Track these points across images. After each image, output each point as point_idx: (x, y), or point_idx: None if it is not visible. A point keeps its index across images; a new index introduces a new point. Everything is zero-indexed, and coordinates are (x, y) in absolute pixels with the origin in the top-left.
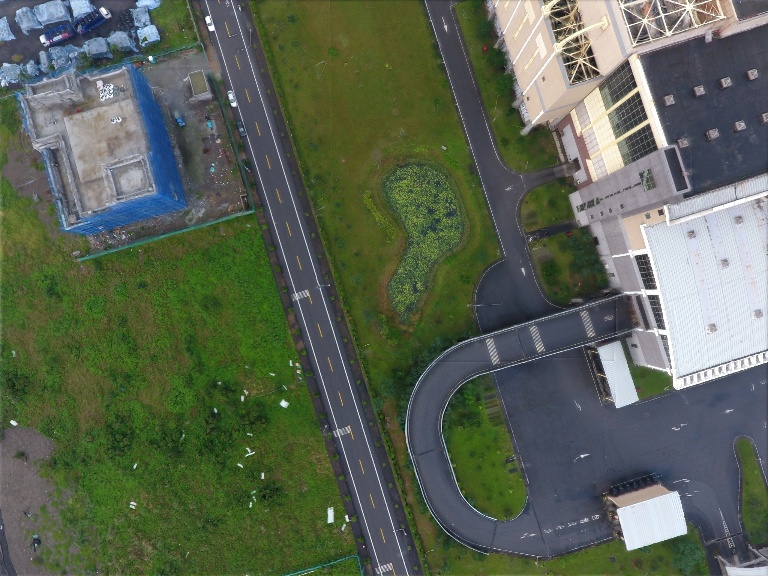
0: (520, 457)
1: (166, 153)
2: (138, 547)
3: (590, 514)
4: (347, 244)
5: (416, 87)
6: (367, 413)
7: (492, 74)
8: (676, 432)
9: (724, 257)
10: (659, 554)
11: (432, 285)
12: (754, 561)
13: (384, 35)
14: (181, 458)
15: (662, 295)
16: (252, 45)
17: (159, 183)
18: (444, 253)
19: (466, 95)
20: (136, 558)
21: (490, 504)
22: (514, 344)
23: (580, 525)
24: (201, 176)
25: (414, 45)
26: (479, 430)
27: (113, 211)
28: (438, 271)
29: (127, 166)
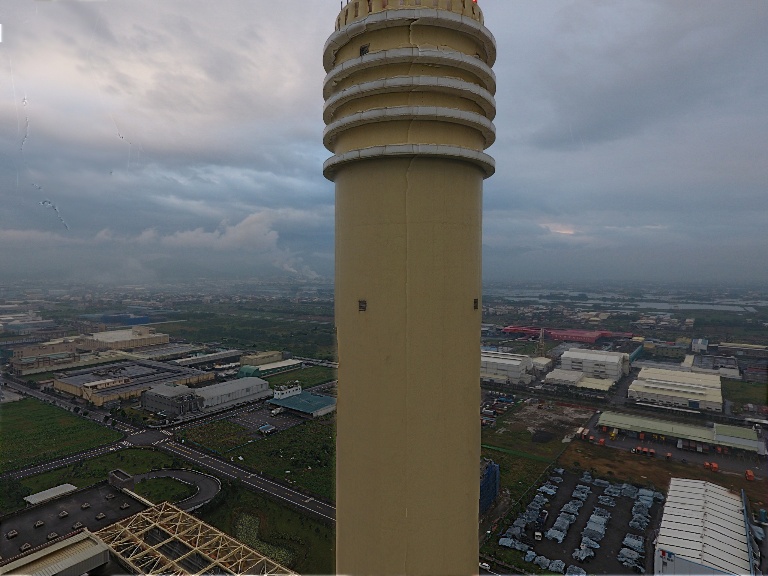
0: None
1: None
2: None
3: None
4: None
5: None
6: None
7: None
8: None
9: None
10: None
11: None
12: None
13: None
14: None
15: None
16: None
17: None
18: None
19: None
20: None
21: None
22: None
23: None
24: None
25: None
26: None
27: None
28: None
29: None
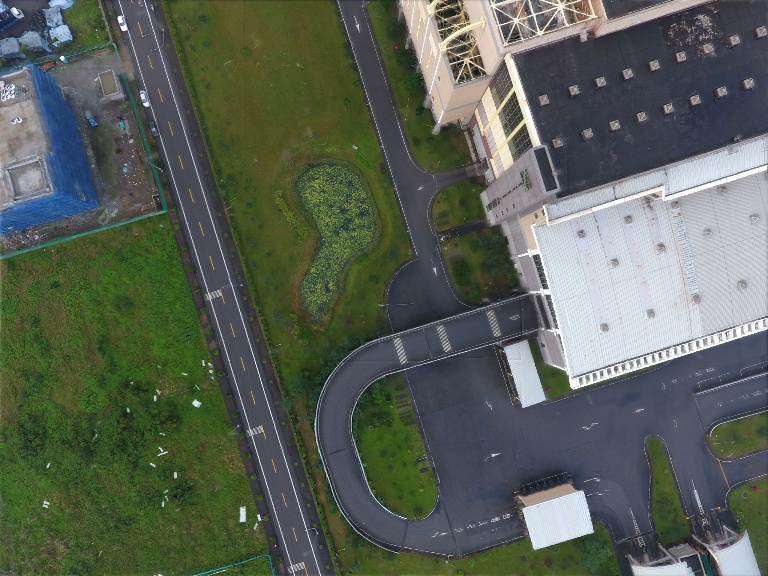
0: (431, 456)
1: (75, 153)
2: (51, 546)
3: (501, 513)
4: (259, 244)
5: (328, 86)
6: (279, 413)
7: (404, 73)
8: (587, 431)
9: (614, 257)
10: (569, 553)
11: (343, 285)
12: (660, 560)
13: (296, 34)
14: (94, 458)
15: (553, 295)
16: (165, 45)
17: (60, 183)
18: (356, 253)
19: (378, 94)
20: (49, 557)
21: (401, 503)
22: (421, 344)
23: (491, 524)
24: (114, 176)
25: (326, 44)
26: (390, 429)
27: (15, 211)
28: (350, 271)
29: (25, 167)
